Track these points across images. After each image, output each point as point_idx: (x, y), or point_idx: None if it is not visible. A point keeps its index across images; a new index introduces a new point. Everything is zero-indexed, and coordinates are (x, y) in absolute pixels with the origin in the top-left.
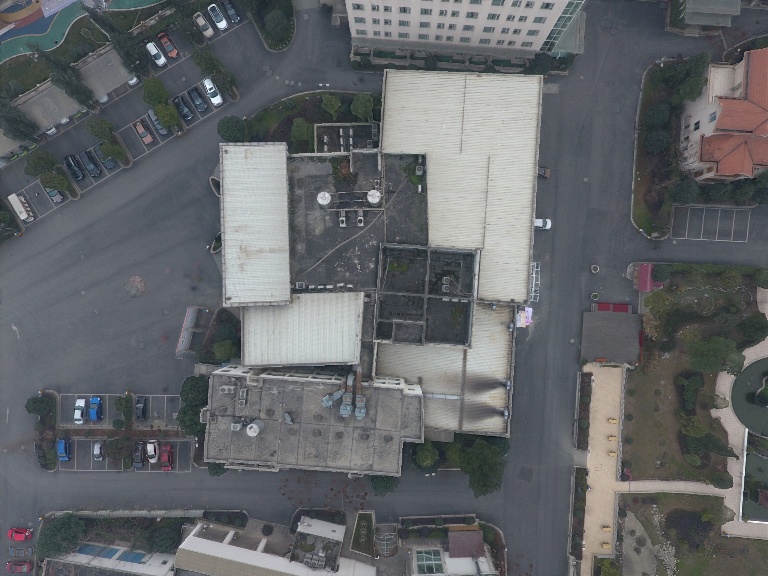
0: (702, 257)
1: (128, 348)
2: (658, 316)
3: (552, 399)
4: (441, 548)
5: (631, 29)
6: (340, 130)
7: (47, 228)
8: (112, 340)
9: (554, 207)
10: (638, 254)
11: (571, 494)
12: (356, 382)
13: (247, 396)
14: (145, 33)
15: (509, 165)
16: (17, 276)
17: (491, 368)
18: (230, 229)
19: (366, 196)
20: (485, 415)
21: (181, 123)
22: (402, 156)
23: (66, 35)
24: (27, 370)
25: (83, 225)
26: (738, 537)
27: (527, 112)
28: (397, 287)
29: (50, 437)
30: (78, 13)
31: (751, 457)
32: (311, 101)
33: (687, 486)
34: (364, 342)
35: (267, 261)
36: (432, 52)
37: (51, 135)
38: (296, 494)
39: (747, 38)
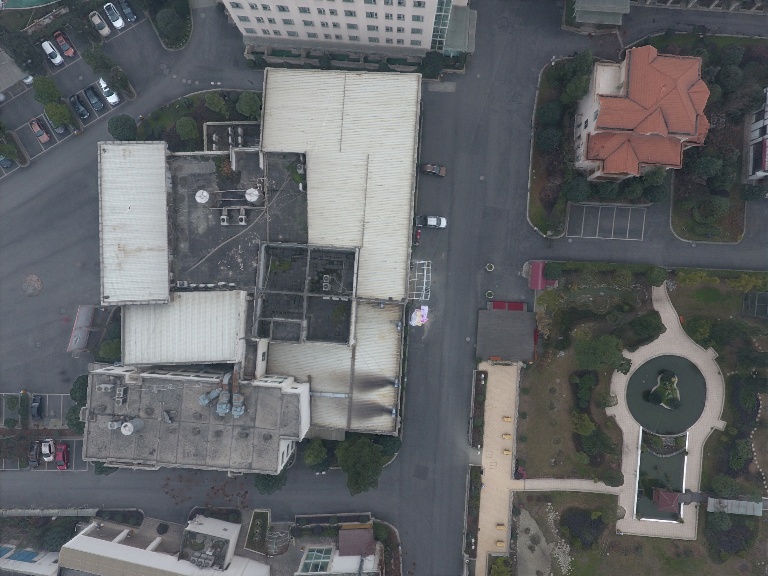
0: (597, 255)
1: (25, 347)
2: (553, 314)
3: (448, 397)
4: (334, 546)
5: (527, 27)
6: (229, 129)
7: None
8: (9, 339)
9: (450, 205)
10: (534, 252)
11: (466, 492)
12: (232, 380)
13: (126, 395)
14: (40, 32)
15: (388, 163)
16: None
17: (380, 366)
18: (108, 228)
19: None
20: (374, 413)
21: (78, 122)
22: (285, 154)
23: None
24: None
25: None
26: (632, 535)
27: (406, 110)
28: (279, 285)
29: None
30: None
31: (646, 455)
32: None
33: (582, 484)
34: (248, 341)
35: (145, 260)
36: (325, 51)
37: None
38: (192, 493)
39: (643, 36)
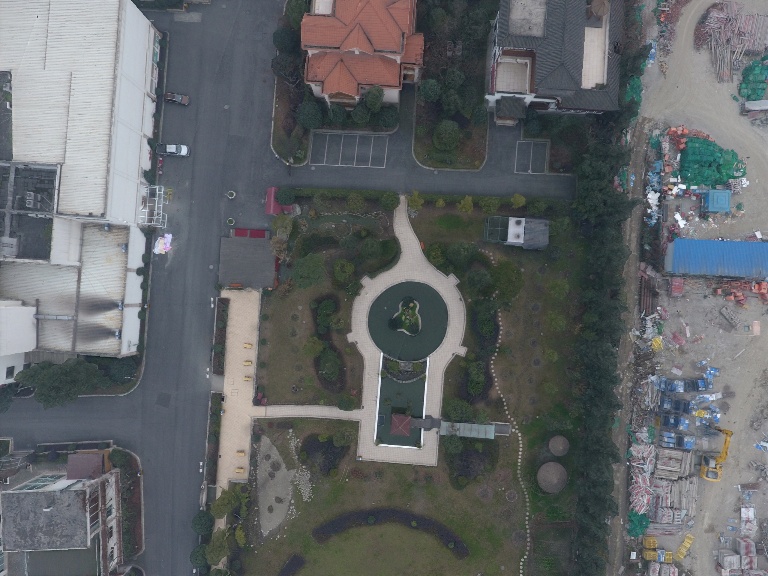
0: (340, 183)
1: None
2: (296, 241)
3: (191, 325)
4: None
5: None
6: None
7: None
8: None
9: (194, 134)
10: (277, 180)
11: (208, 419)
12: None
13: None
14: None
15: (90, 80)
16: None
17: (107, 289)
18: None
19: None
20: (100, 336)
21: None
22: None
23: None
24: None
25: None
26: (373, 461)
27: (107, 28)
28: None
29: None
30: None
31: (387, 381)
32: None
33: (323, 411)
34: None
35: None
36: None
37: None
38: None
39: None
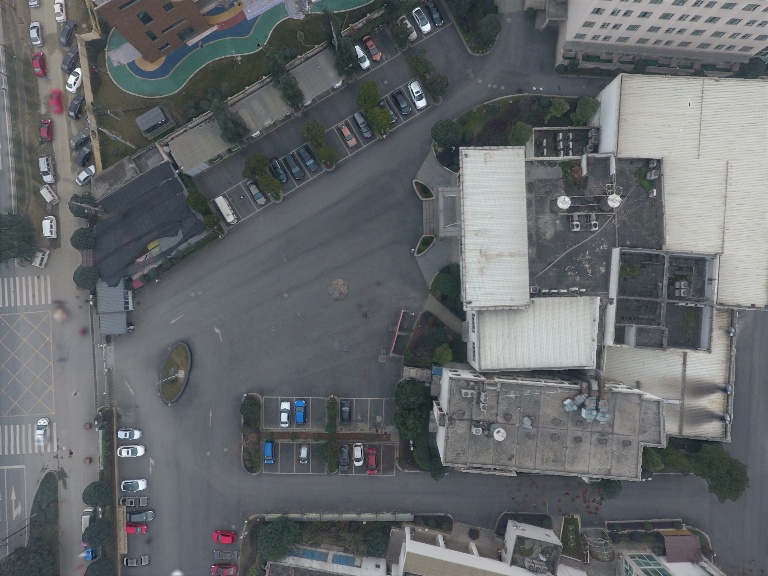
0: None
1: (331, 351)
2: None
3: (758, 404)
4: (652, 553)
5: None
6: (560, 134)
7: (249, 231)
8: (315, 343)
9: None
10: None
11: None
12: (600, 387)
13: None
14: (352, 36)
15: (748, 170)
16: (219, 279)
17: (710, 373)
18: (470, 233)
19: (597, 200)
20: (704, 420)
21: None
22: (632, 160)
23: (269, 38)
24: (230, 373)
25: (285, 228)
26: None
27: (766, 117)
28: (629, 291)
29: (255, 440)
30: (281, 16)
31: None
32: (520, 105)
33: None
34: None
35: (507, 265)
36: (644, 56)
37: (254, 138)
38: (501, 498)
39: None
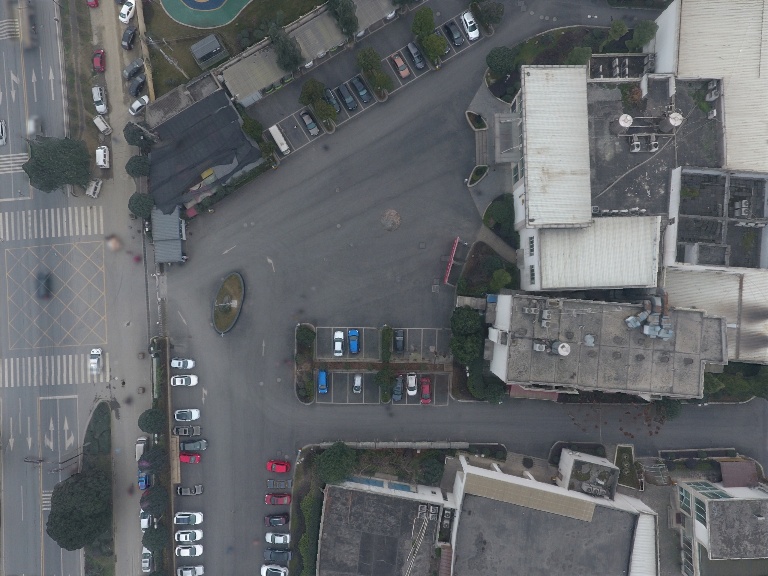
0: None
1: (384, 281)
2: None
3: None
4: (706, 480)
5: None
6: (616, 60)
7: (302, 161)
8: (368, 273)
9: None
10: None
11: None
12: (664, 303)
13: None
14: None
15: None
16: (272, 209)
17: (766, 298)
18: (532, 151)
19: (656, 122)
20: (761, 344)
21: None
22: (691, 82)
23: None
24: (283, 303)
25: (338, 159)
26: None
27: None
28: (688, 212)
29: (308, 369)
30: None
31: None
32: (574, 34)
33: None
34: None
35: (569, 183)
36: None
37: (307, 69)
38: (554, 427)
39: None
